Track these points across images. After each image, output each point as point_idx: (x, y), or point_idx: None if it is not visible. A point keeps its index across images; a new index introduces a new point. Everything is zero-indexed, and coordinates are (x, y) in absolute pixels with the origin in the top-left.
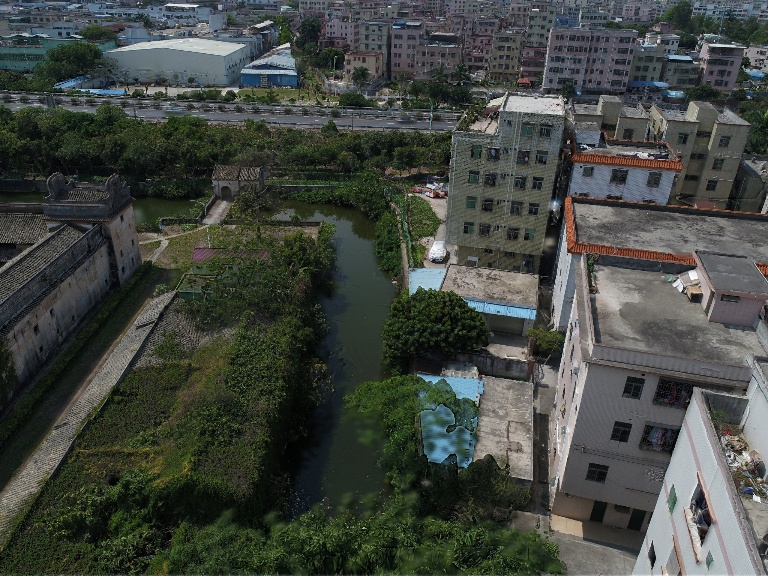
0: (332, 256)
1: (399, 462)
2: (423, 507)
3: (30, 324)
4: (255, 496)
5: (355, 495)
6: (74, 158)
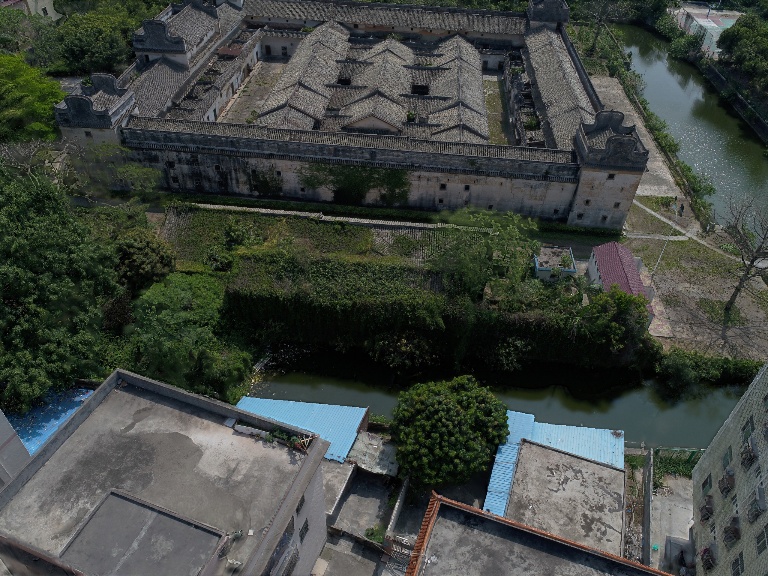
0: (679, 367)
1: None
2: (157, 355)
3: (439, 180)
4: (232, 296)
5: (282, 390)
6: None
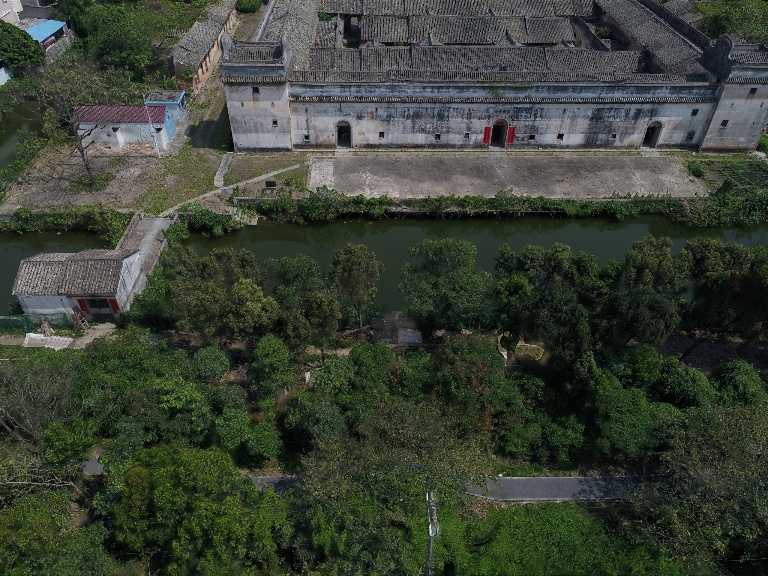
0: None
1: (79, 1)
2: None
3: None
4: None
5: None
6: (515, 371)
